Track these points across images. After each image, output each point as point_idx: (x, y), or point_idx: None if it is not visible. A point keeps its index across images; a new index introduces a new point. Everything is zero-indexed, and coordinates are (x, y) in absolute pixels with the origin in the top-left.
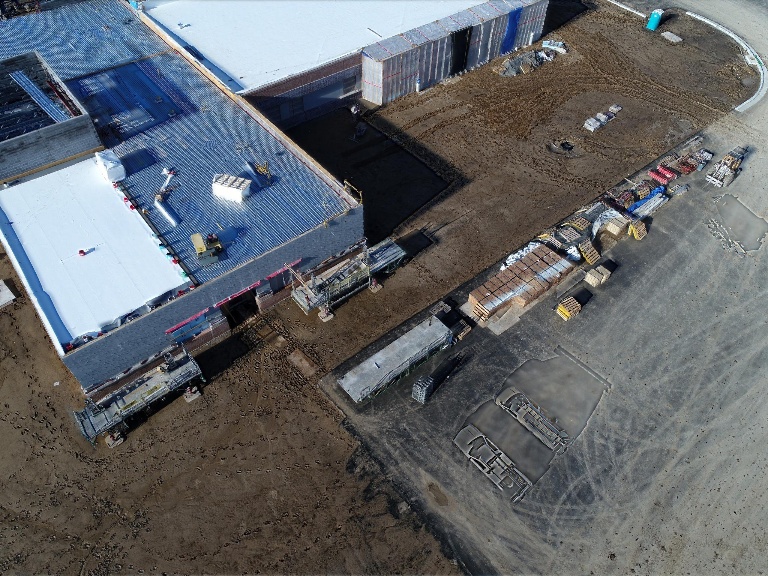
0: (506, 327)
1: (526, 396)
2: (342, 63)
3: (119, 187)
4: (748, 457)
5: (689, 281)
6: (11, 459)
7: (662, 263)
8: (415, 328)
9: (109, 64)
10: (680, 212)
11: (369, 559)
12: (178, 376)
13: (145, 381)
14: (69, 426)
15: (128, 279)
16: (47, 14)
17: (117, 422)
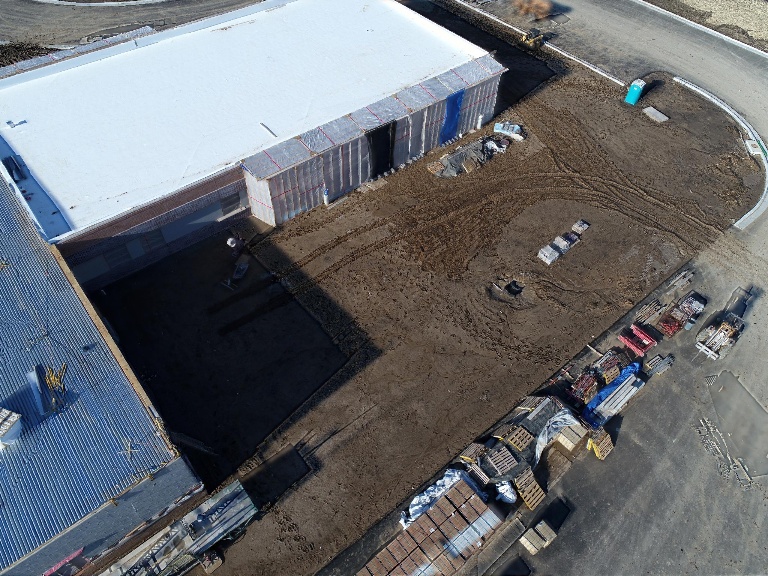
0: None
1: None
2: (213, 182)
3: None
4: None
5: (671, 539)
6: None
7: (633, 504)
8: None
9: None
10: (660, 405)
11: None
12: None
13: None
14: None
15: None
16: None
17: None
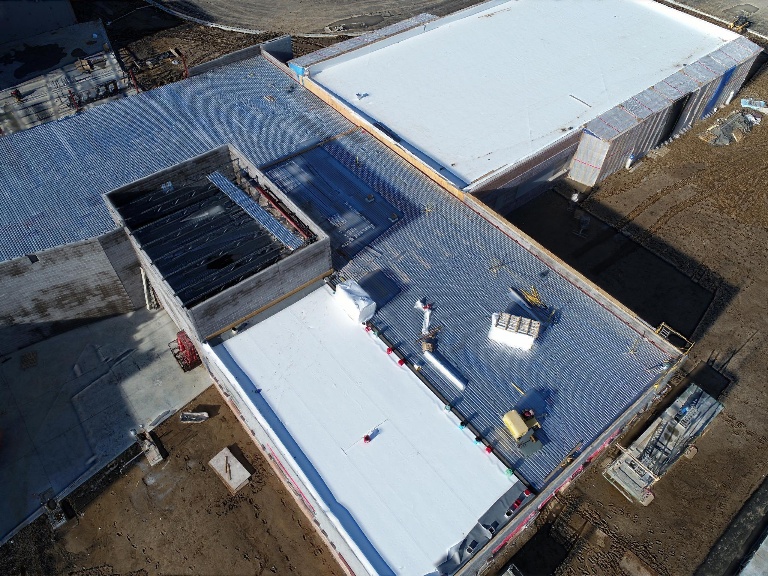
0: None
1: None
2: (563, 143)
3: (376, 332)
4: None
5: None
6: None
7: None
8: None
9: (290, 147)
10: None
11: None
12: None
13: None
14: None
15: (439, 480)
16: (196, 81)
17: None
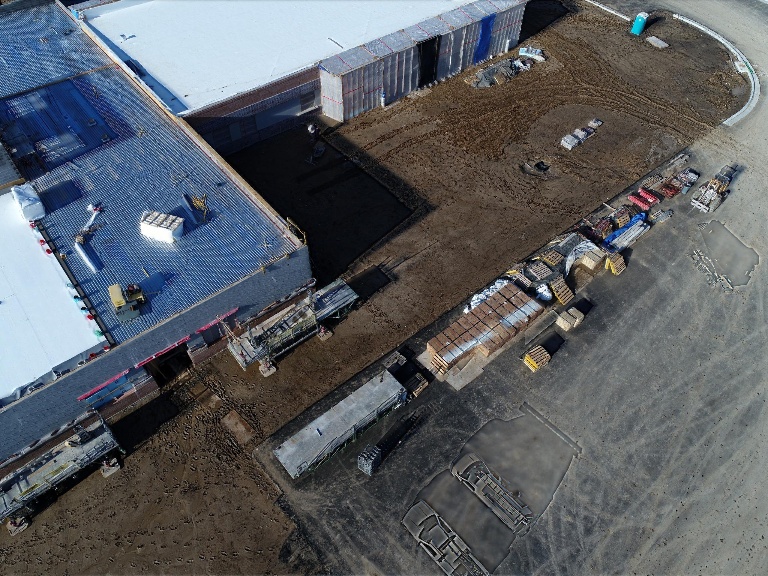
0: (467, 381)
1: (486, 464)
2: (297, 78)
3: (36, 227)
4: (733, 536)
5: (671, 323)
6: None
7: (641, 302)
8: (364, 385)
9: (43, 81)
10: (662, 242)
11: None
12: (91, 450)
13: (53, 456)
14: None
15: (35, 339)
16: None
17: (17, 508)
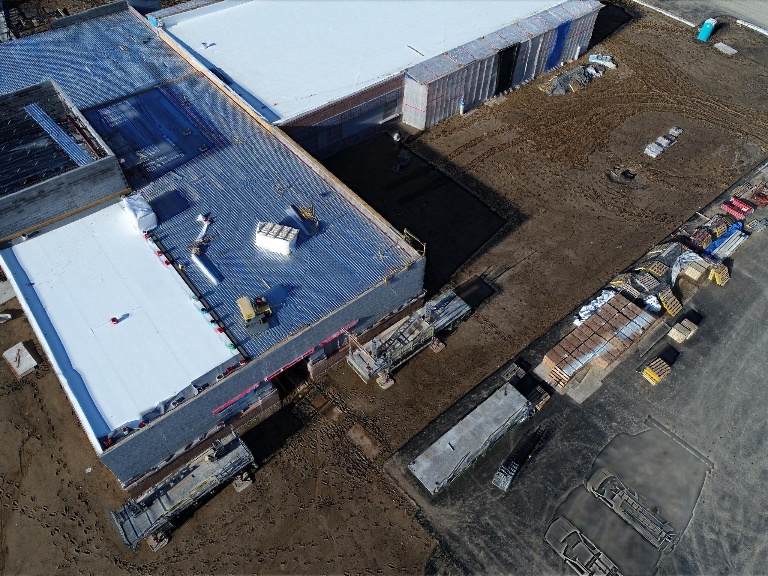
0: (588, 394)
1: (620, 480)
2: (384, 86)
3: (151, 238)
4: None
5: None
6: (41, 567)
7: (751, 313)
8: (489, 399)
9: (130, 90)
10: (762, 252)
11: None
12: (228, 464)
13: (191, 471)
14: (105, 524)
15: (169, 353)
16: (59, 32)
17: (162, 524)
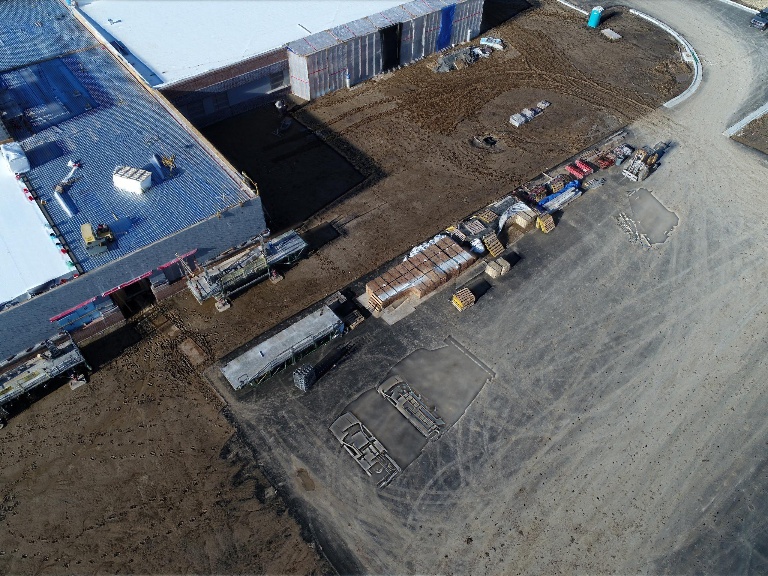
0: (400, 317)
1: (409, 385)
2: (266, 58)
3: (21, 178)
4: (620, 445)
5: (590, 273)
6: None
7: (566, 255)
8: (306, 318)
9: (35, 59)
10: (592, 206)
11: (229, 542)
12: (61, 363)
13: (27, 368)
14: None
15: (14, 268)
16: None
17: None
